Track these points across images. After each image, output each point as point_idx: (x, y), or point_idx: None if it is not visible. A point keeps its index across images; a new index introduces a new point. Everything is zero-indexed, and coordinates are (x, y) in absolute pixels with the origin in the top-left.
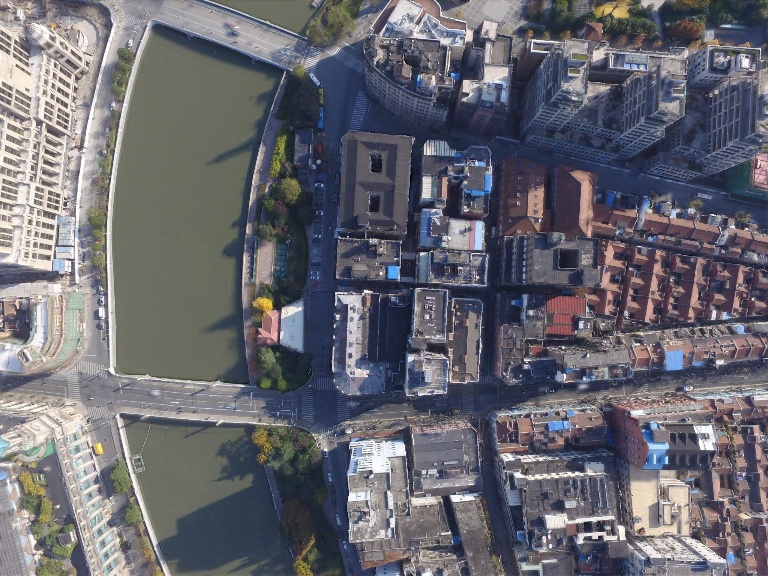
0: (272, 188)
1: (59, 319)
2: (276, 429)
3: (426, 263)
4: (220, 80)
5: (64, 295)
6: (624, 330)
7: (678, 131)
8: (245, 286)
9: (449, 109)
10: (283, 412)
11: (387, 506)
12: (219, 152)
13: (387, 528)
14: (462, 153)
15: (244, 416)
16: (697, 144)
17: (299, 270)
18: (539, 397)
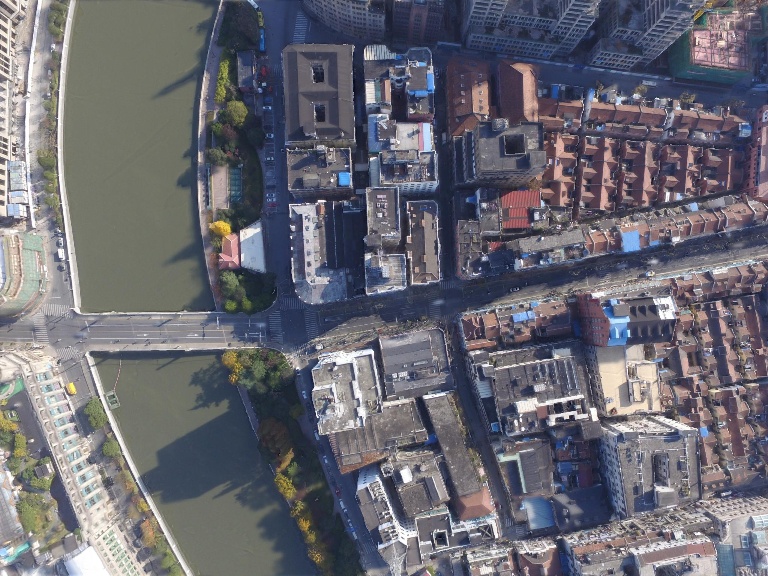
0: (220, 114)
1: (17, 259)
2: (246, 350)
3: (377, 167)
4: (158, 13)
5: (19, 235)
6: (582, 222)
7: (614, 14)
8: (202, 214)
9: (388, 18)
10: (252, 335)
11: (353, 396)
12: (164, 84)
13: (355, 418)
14: (403, 56)
15: (213, 342)
16: (633, 25)
17: (255, 193)
18: (504, 296)
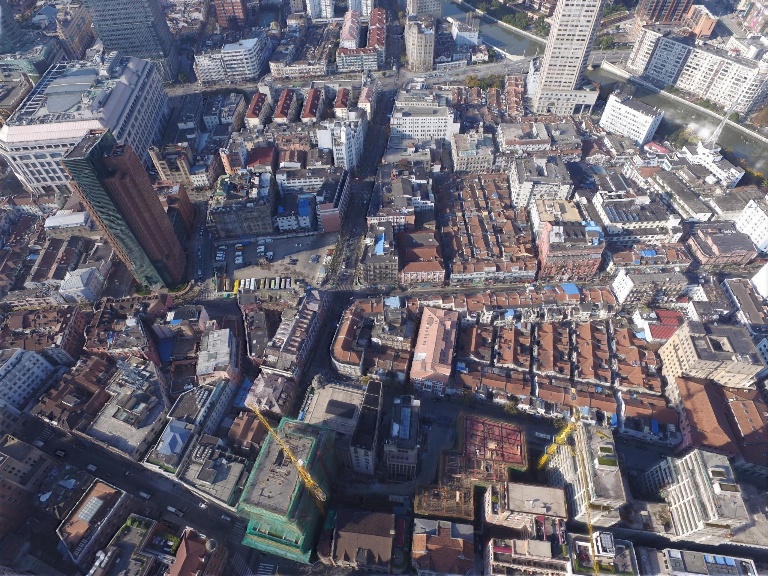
0: None
1: None
2: None
3: None
4: None
5: None
6: None
7: None
8: None
9: None
10: None
11: None
12: None
13: None
14: None
15: None
16: None
17: None
18: None
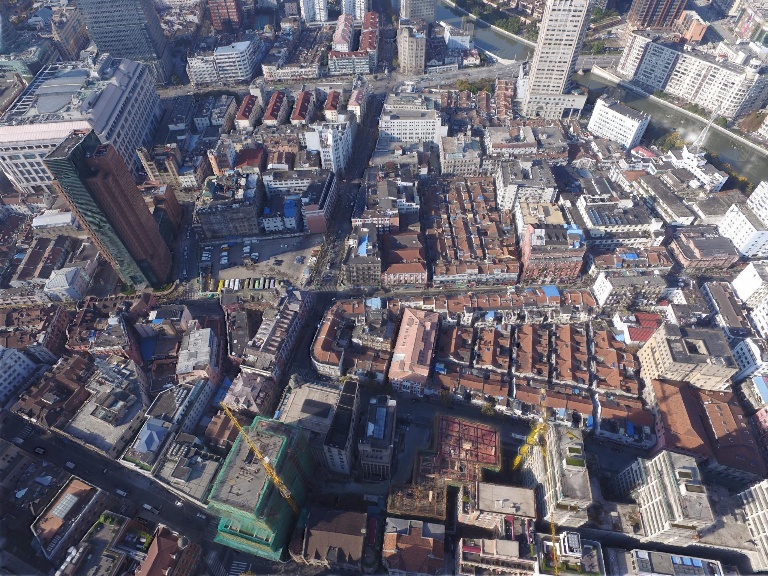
0: None
1: None
2: None
3: None
4: None
5: None
6: None
7: None
8: None
9: None
10: None
11: None
12: None
13: None
14: None
15: None
16: None
17: None
18: None
